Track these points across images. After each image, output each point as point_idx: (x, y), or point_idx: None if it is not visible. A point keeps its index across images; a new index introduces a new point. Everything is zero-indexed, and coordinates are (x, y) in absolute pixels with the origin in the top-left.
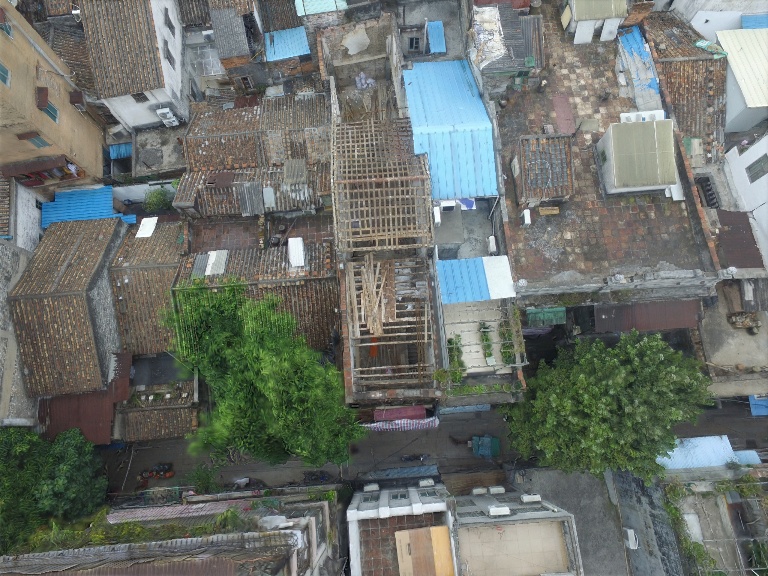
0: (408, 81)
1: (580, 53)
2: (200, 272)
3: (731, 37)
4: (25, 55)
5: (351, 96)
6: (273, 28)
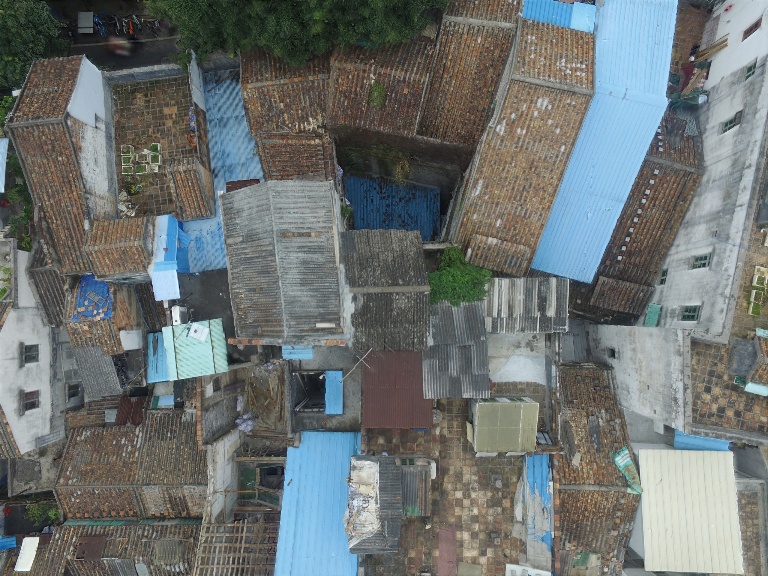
0: (289, 476)
1: (480, 470)
2: None
3: (654, 462)
4: None
5: (256, 373)
6: (159, 324)
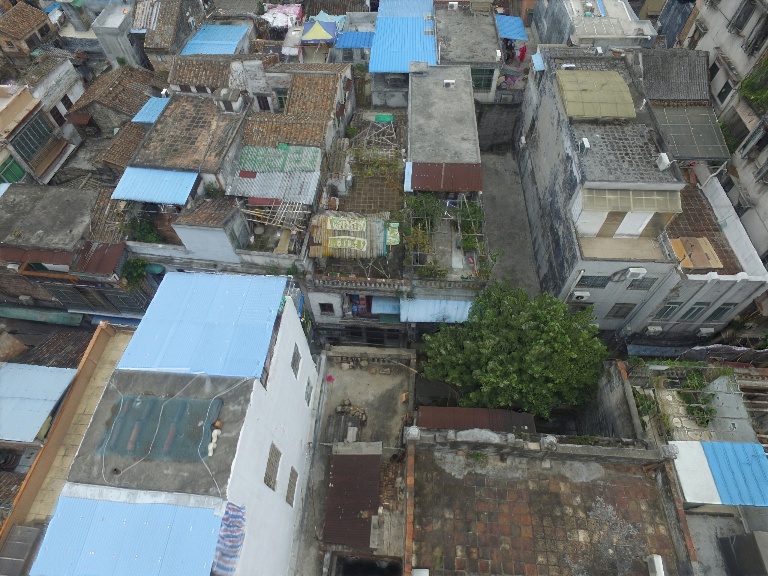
0: None
1: None
2: None
3: None
4: None
5: None
6: None
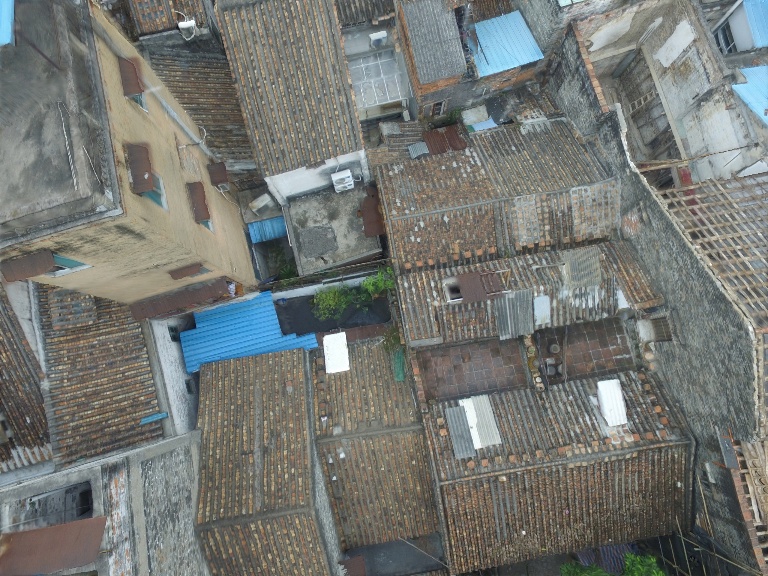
0: (759, 108)
1: None
2: (465, 444)
3: None
4: (163, 133)
5: None
6: None
